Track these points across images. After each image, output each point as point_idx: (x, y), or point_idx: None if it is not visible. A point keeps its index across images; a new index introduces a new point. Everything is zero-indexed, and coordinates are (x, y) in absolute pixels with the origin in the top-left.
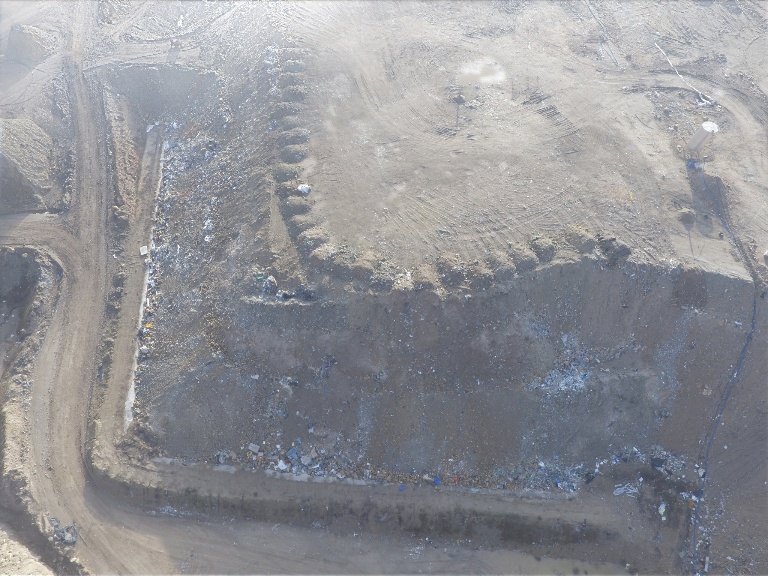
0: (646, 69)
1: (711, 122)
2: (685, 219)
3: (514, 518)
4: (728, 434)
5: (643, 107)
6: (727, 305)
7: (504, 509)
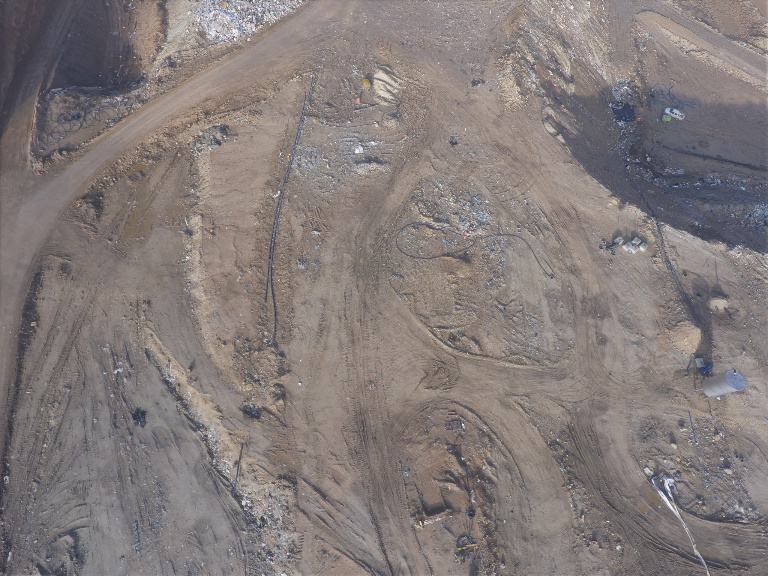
0: (756, 574)
1: (735, 388)
2: (723, 295)
3: (752, 168)
4: (622, 175)
5: (761, 482)
6: (675, 220)
7: (760, 173)
